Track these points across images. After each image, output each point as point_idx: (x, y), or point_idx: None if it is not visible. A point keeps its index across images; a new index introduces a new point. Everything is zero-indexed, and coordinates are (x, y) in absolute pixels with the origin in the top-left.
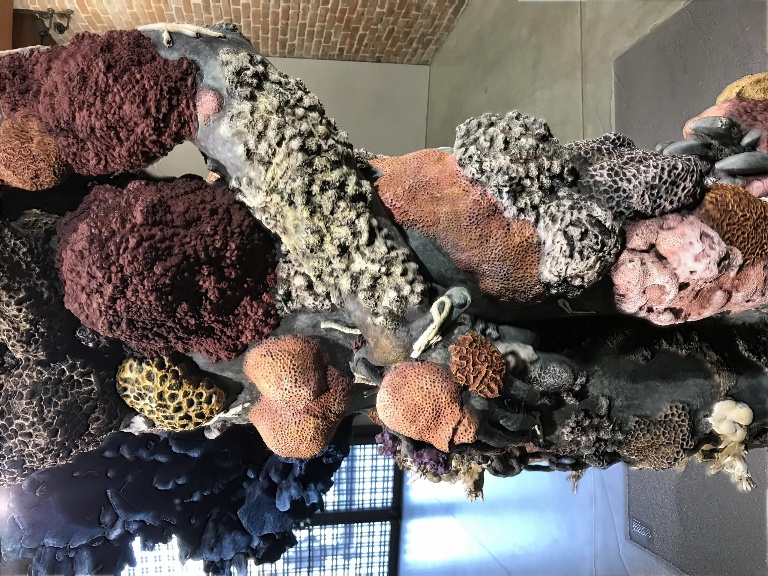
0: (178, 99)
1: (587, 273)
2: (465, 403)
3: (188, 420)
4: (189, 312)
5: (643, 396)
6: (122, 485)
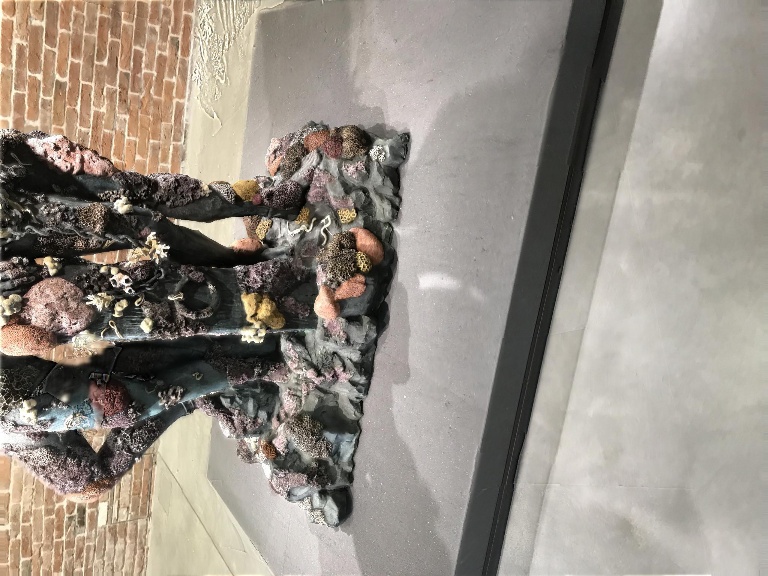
0: None
1: None
2: None
3: None
4: None
5: None
6: None
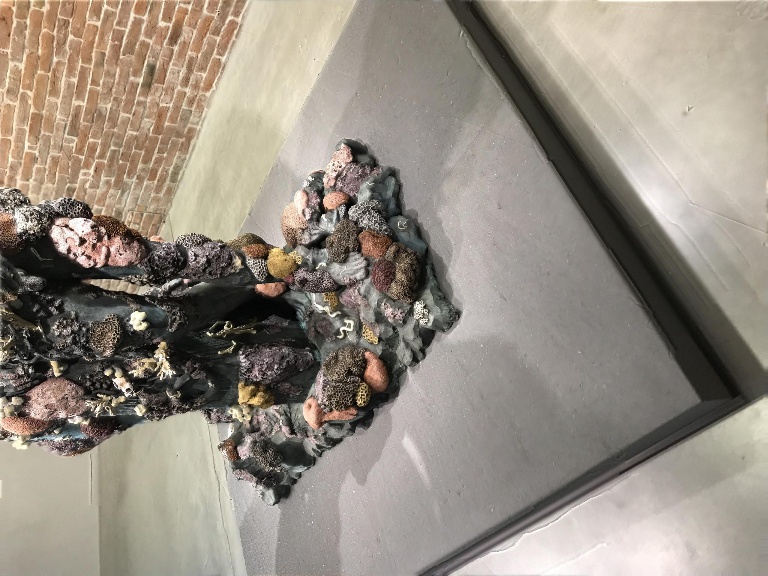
0: None
1: (35, 228)
2: None
3: None
4: None
5: (94, 312)
6: None
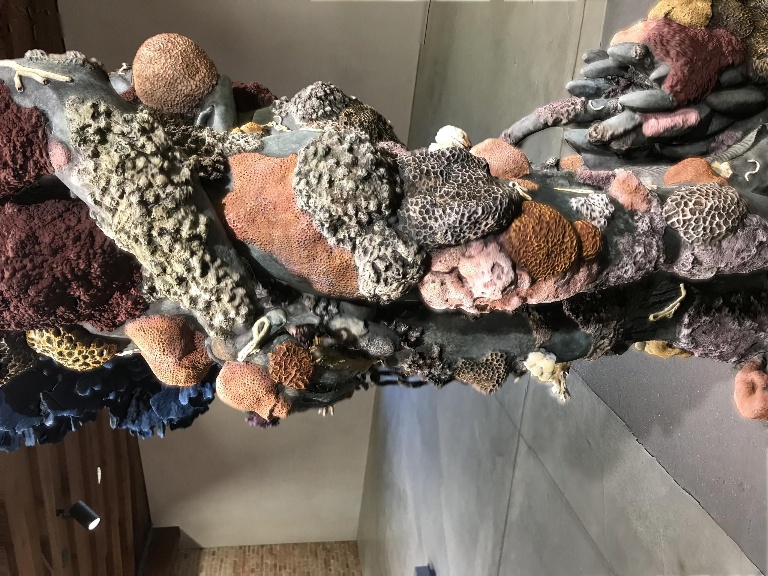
0: (32, 150)
1: (392, 293)
2: (281, 391)
3: (87, 366)
4: (67, 311)
5: (470, 345)
6: (55, 383)
